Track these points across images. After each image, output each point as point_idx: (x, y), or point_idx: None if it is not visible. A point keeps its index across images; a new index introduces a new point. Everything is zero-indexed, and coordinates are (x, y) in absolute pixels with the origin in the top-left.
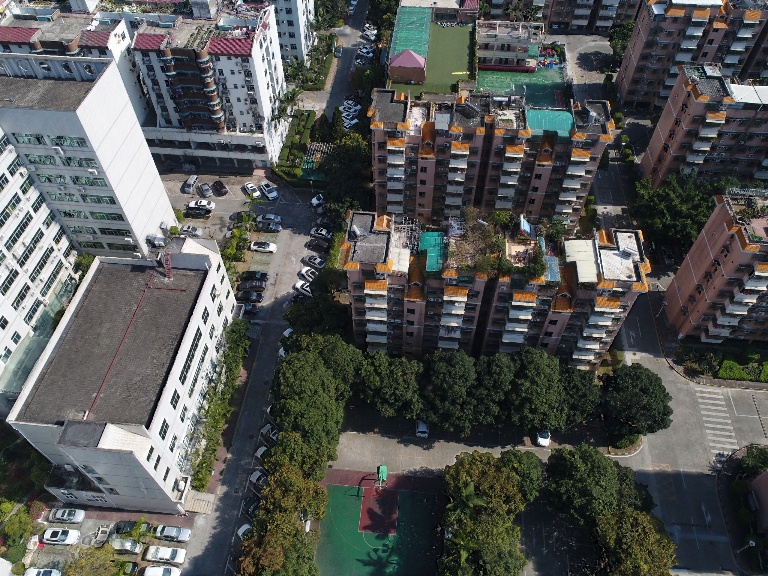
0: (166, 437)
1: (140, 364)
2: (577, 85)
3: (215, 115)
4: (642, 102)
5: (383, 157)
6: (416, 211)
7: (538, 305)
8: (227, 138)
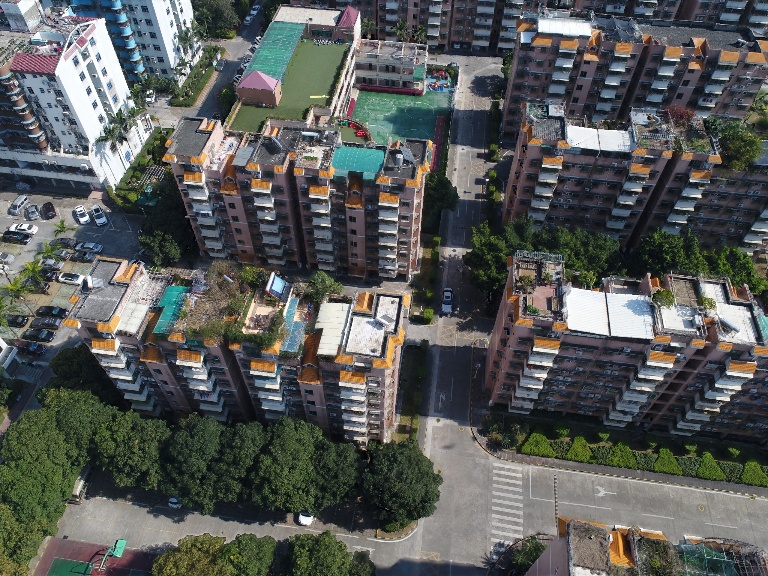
0: None
1: None
2: (463, 111)
3: (32, 135)
4: None
5: (186, 191)
6: (238, 247)
7: (286, 374)
8: (51, 159)
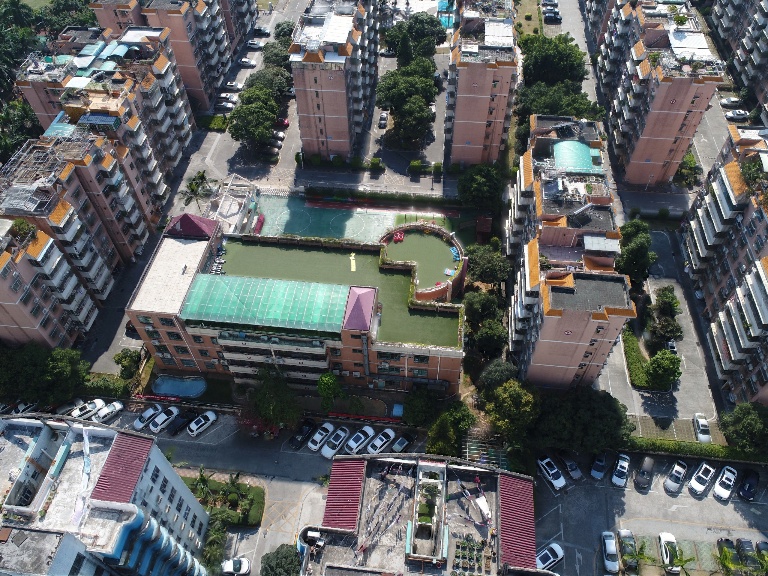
0: None
1: None
2: None
3: None
4: None
5: None
6: None
7: None
8: None
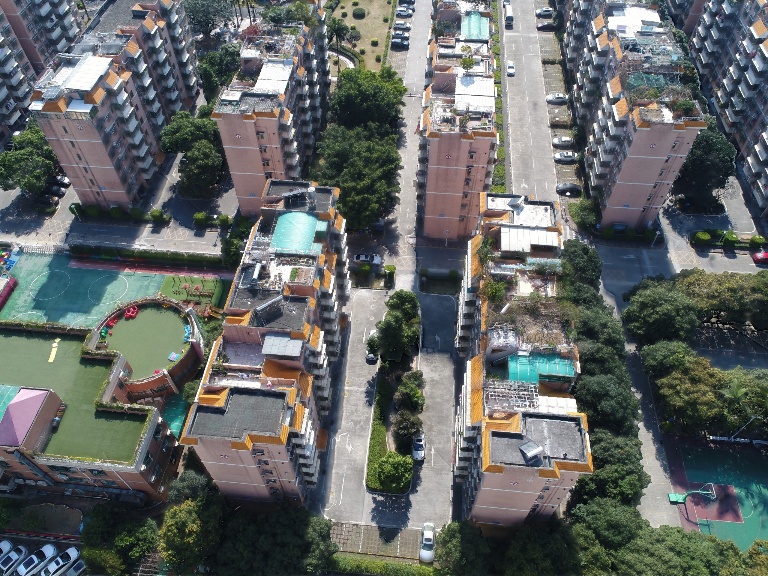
0: None
1: None
2: (67, 243)
3: None
4: (139, 189)
5: (294, 450)
6: None
7: None
8: None
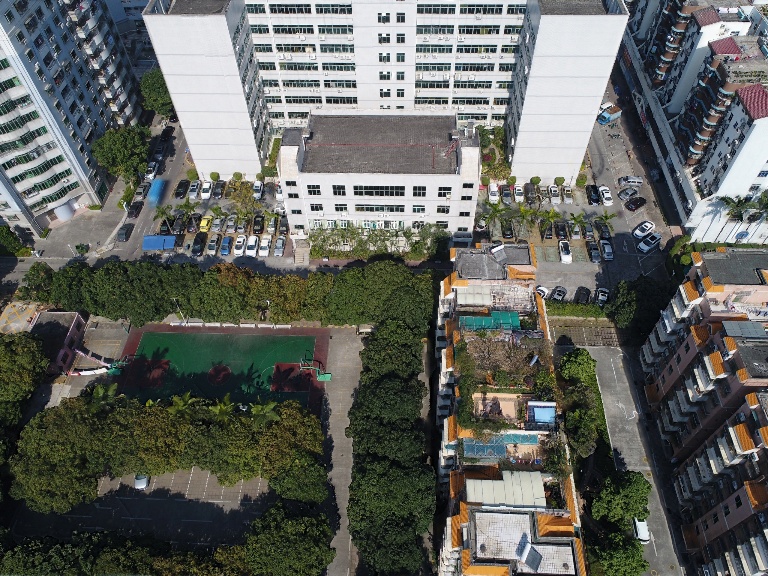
0: (313, 196)
1: (360, 159)
2: None
3: (693, 148)
4: None
5: None
6: (658, 379)
7: None
8: (683, 176)
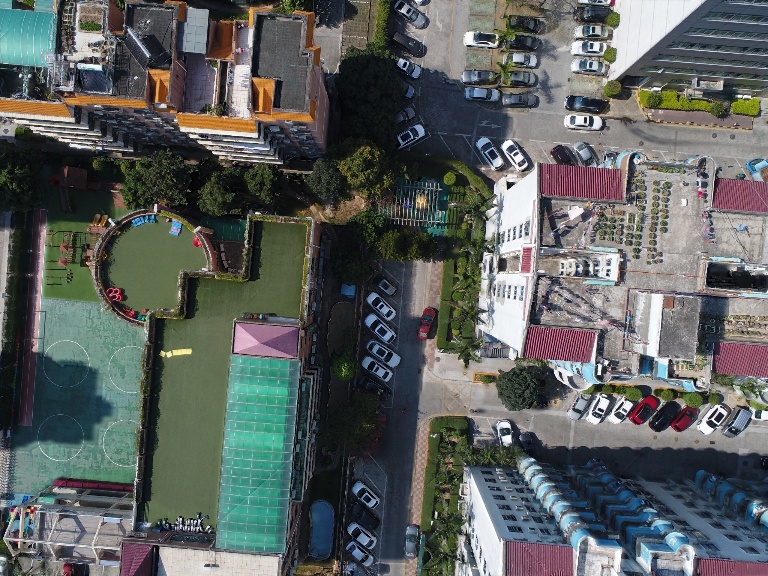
0: None
1: None
2: None
3: None
4: None
5: None
6: None
7: None
8: None
